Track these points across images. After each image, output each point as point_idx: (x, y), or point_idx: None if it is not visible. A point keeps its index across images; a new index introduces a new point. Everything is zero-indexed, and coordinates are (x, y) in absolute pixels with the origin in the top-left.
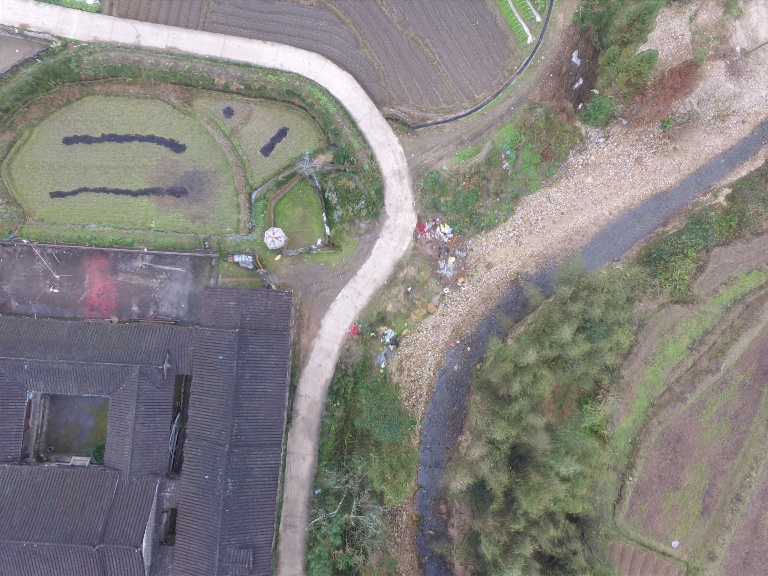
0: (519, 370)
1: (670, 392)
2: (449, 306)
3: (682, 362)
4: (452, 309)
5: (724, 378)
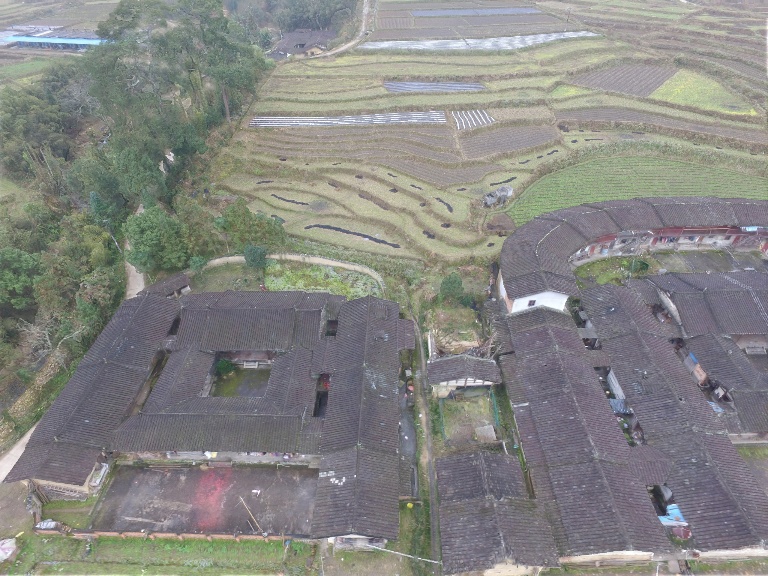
0: None
1: None
2: None
3: None
4: None
5: None
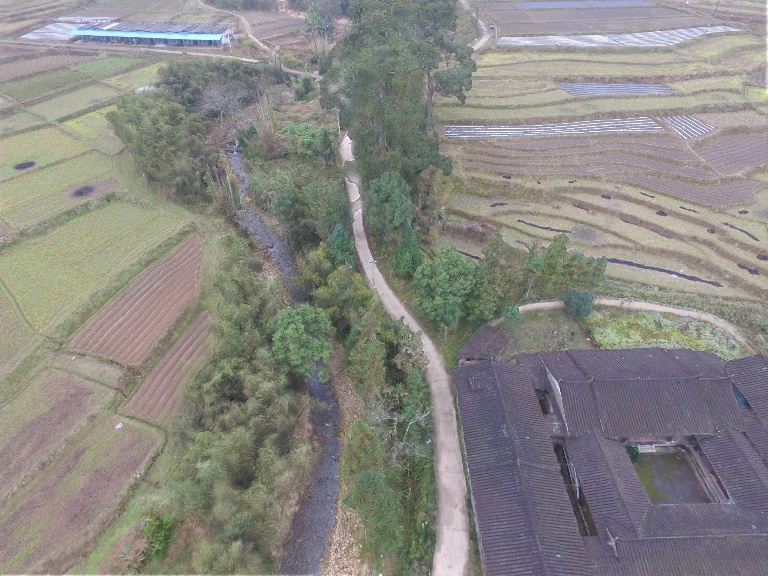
0: (228, 573)
1: (58, 573)
2: None
3: None
4: None
5: None
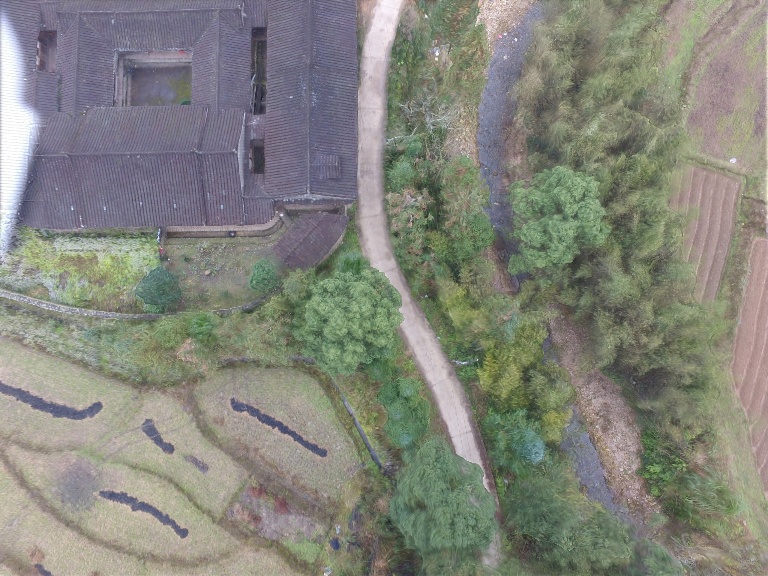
0: None
1: (714, 31)
2: (494, 1)
3: (722, 5)
4: (497, 3)
5: (764, 11)
